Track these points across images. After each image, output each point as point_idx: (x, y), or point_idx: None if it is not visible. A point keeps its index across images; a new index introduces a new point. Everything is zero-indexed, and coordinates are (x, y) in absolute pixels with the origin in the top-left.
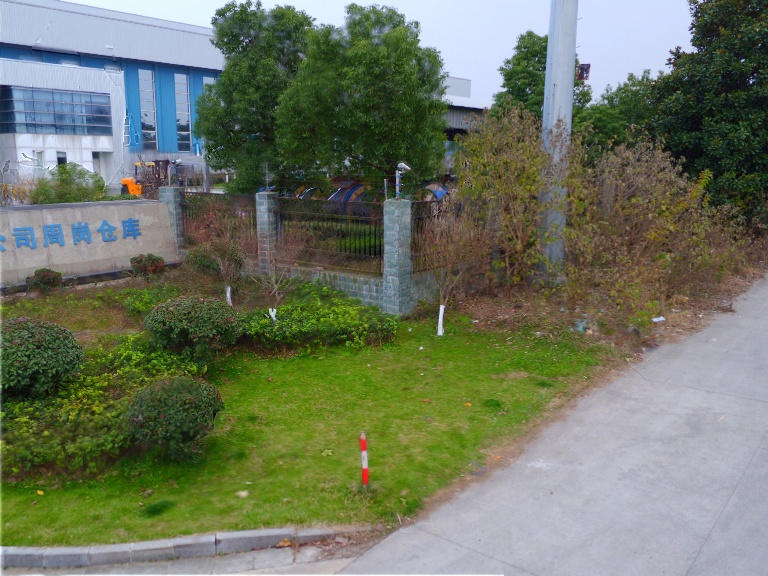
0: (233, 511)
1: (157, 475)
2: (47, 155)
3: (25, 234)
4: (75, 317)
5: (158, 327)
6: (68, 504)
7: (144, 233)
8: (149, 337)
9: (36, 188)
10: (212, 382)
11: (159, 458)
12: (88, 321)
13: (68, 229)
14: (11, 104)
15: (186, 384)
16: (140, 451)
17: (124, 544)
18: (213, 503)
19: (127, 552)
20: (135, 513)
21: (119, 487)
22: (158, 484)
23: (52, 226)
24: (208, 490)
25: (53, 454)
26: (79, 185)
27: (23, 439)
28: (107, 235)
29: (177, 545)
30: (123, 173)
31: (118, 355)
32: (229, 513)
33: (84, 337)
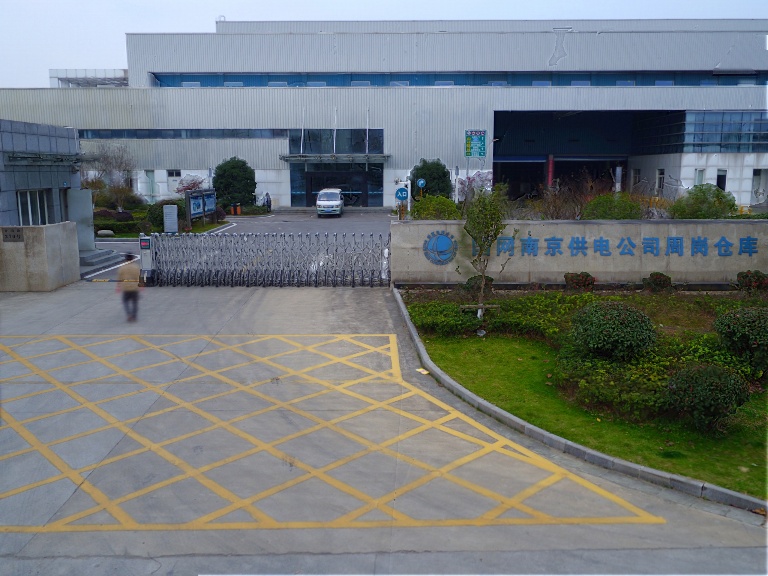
0: (728, 476)
1: (682, 435)
2: (708, 173)
3: (652, 243)
4: (672, 315)
5: (723, 329)
6: (613, 432)
7: (761, 251)
8: (718, 338)
9: (674, 205)
10: (766, 387)
11: (688, 425)
12: (682, 320)
13: (688, 242)
14: (683, 127)
15: (718, 371)
16: (676, 416)
17: (637, 465)
18: (715, 466)
19: (637, 470)
20: (654, 452)
21: (651, 434)
22: (680, 441)
23: (675, 238)
24: (717, 458)
25: (612, 397)
26: (711, 204)
27: (597, 383)
28: (723, 250)
29: (673, 478)
30: (756, 193)
31: (688, 347)
32: (724, 476)
33: (672, 331)
